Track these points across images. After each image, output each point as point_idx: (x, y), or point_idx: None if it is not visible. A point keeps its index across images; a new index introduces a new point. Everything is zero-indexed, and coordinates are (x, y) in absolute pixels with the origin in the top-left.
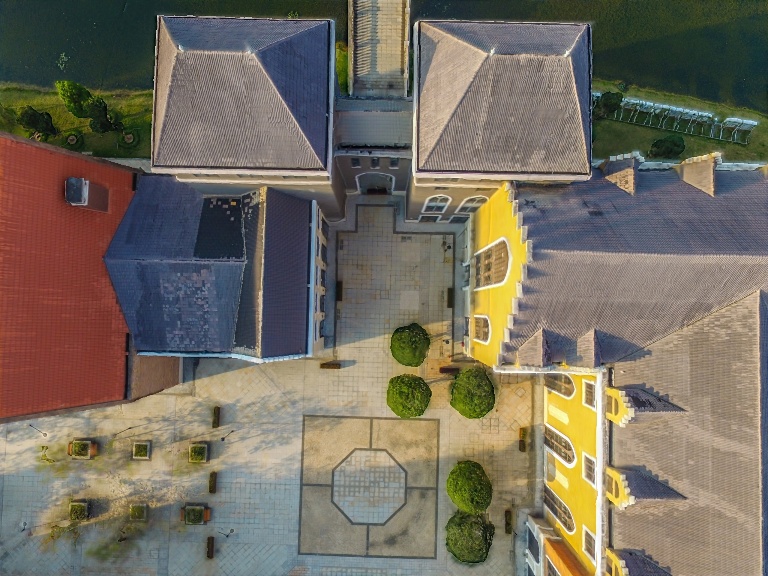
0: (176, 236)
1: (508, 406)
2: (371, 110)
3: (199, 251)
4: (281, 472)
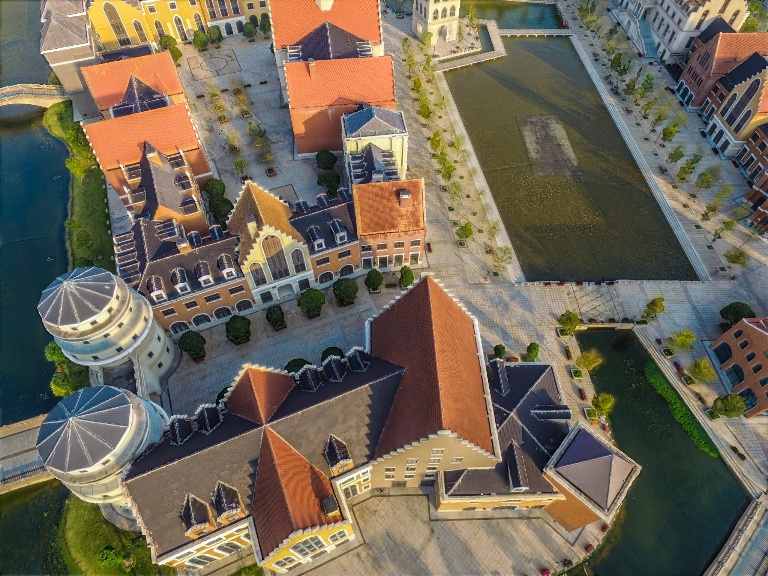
0: None
1: (178, 48)
2: None
3: None
4: (216, 80)
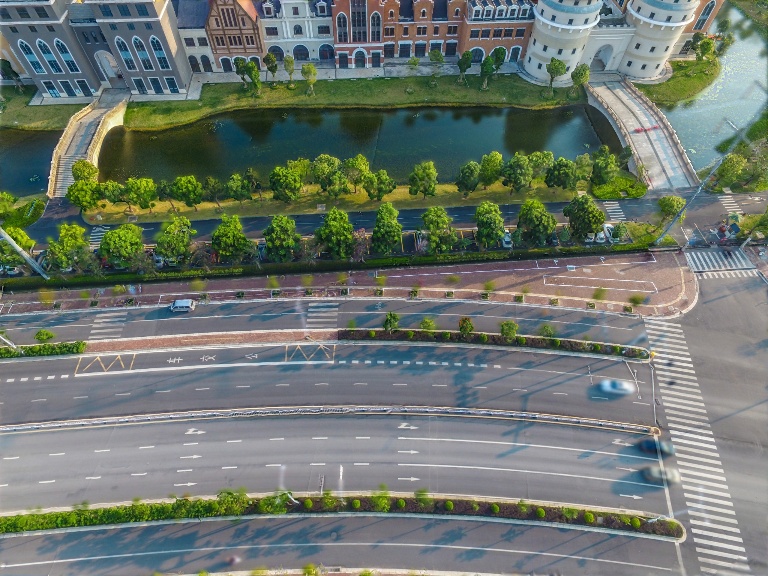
0: (187, 6)
1: None
2: (85, 4)
3: (177, 1)
4: None
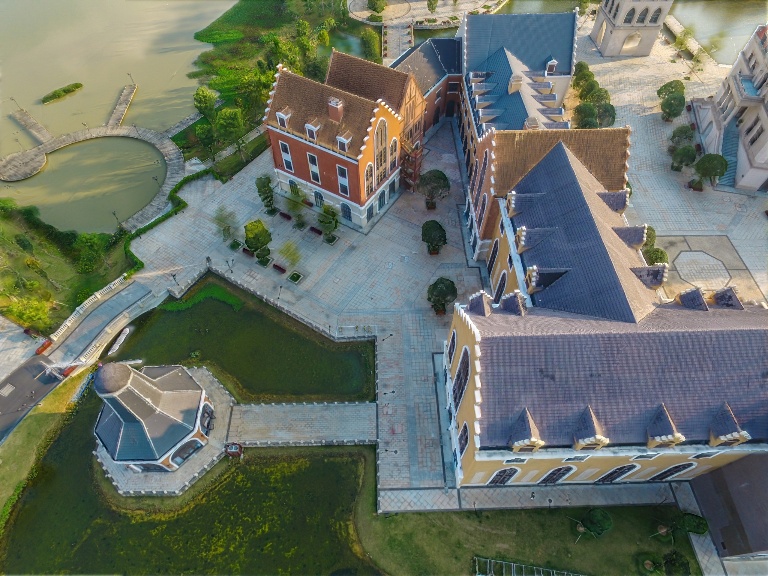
0: None
1: None
2: None
3: None
4: (766, 276)
